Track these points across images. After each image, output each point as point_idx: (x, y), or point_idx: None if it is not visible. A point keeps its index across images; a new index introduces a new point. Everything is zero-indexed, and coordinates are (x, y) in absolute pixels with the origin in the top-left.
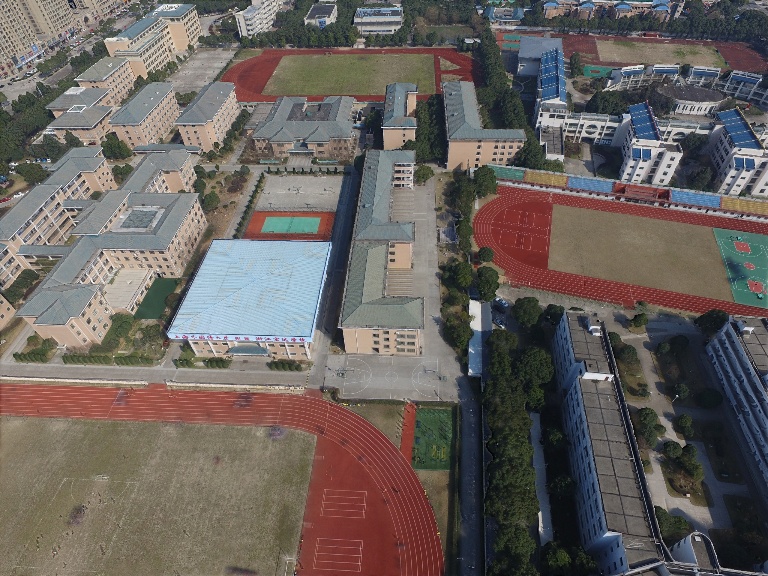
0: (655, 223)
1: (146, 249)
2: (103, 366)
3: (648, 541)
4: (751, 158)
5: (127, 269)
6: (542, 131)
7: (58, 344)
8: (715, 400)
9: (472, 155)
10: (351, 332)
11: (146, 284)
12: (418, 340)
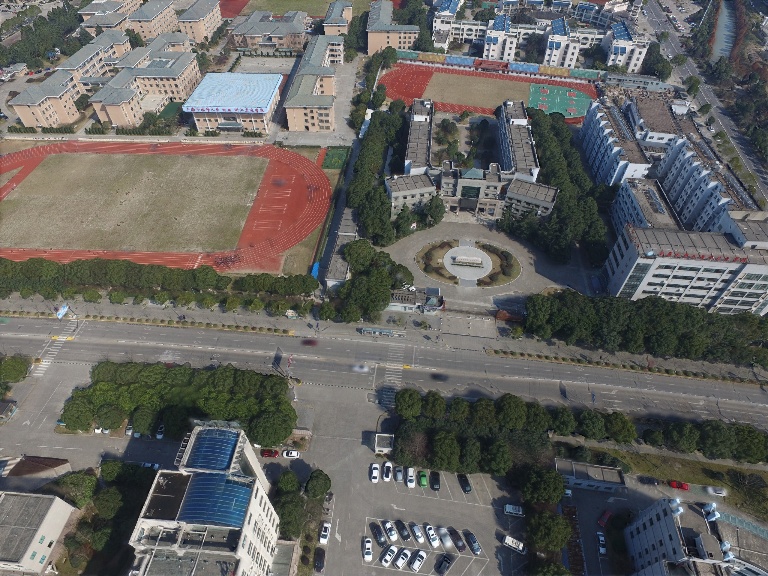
0: (496, 81)
1: (165, 76)
2: (141, 136)
3: (424, 163)
4: (559, 41)
5: (151, 94)
6: (436, 32)
7: (113, 124)
8: (490, 140)
9: (384, 44)
10: (291, 112)
11: (164, 102)
12: (331, 118)
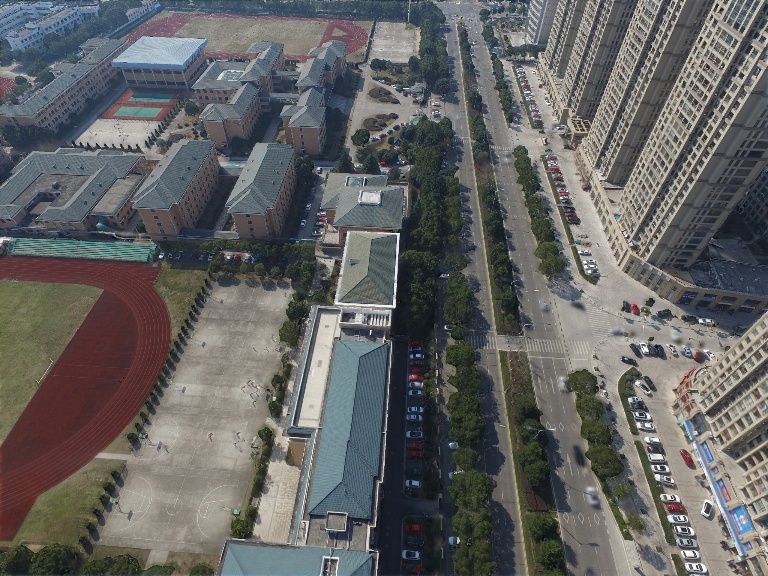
0: None
1: None
2: None
3: None
4: None
5: None
6: None
7: None
8: None
9: None
10: None
11: None
12: None
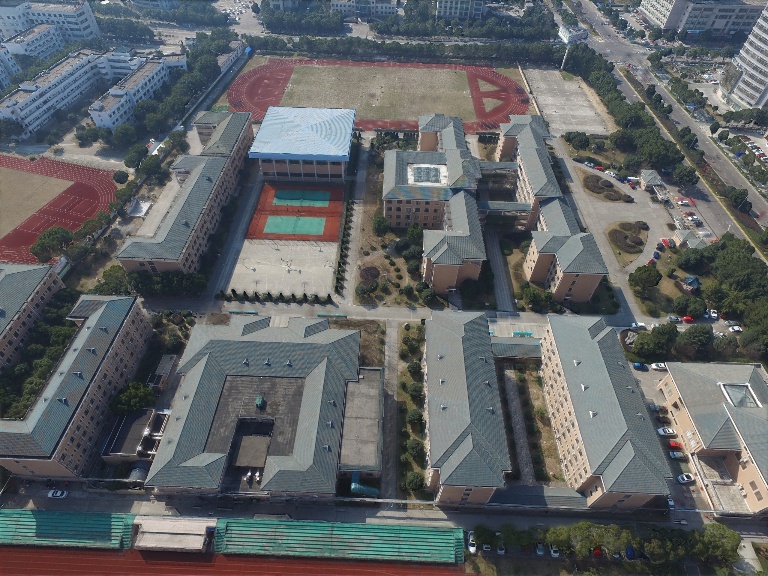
0: None
1: None
2: None
3: None
4: None
5: None
6: None
7: None
8: None
9: None
10: None
11: None
12: None
